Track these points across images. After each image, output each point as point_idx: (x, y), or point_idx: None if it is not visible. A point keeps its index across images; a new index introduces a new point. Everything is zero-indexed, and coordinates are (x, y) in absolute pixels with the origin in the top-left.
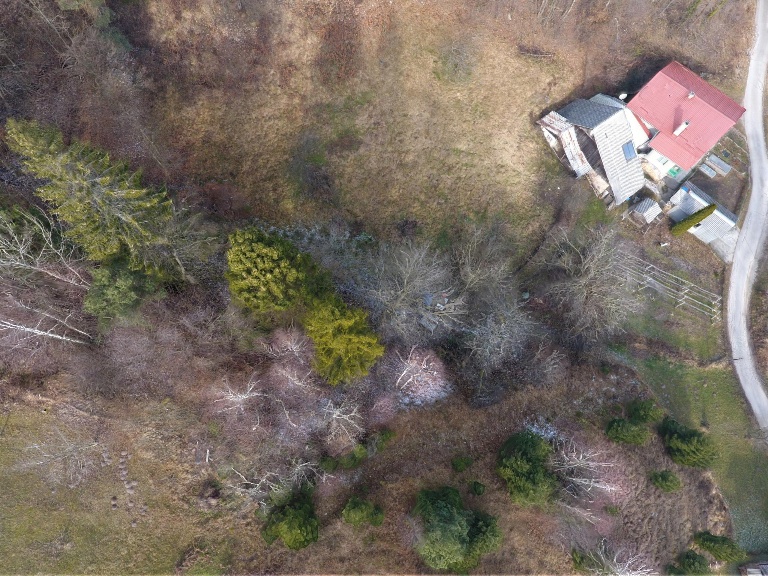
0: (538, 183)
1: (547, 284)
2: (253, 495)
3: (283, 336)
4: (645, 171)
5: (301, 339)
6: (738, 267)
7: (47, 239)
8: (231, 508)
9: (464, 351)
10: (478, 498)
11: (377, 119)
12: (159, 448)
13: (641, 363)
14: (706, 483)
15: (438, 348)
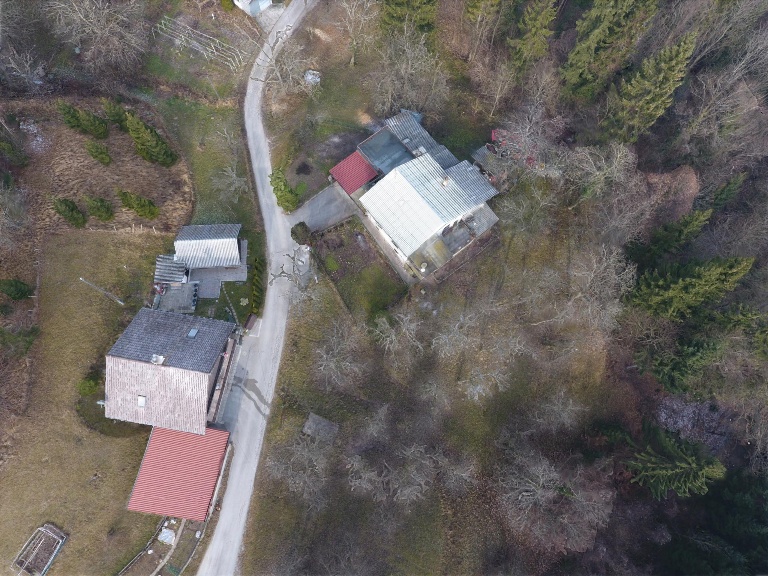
0: None
1: None
2: None
3: None
4: None
5: None
6: (274, 35)
7: None
8: None
9: (2, 85)
10: None
11: None
12: None
13: (163, 101)
14: (181, 182)
15: None
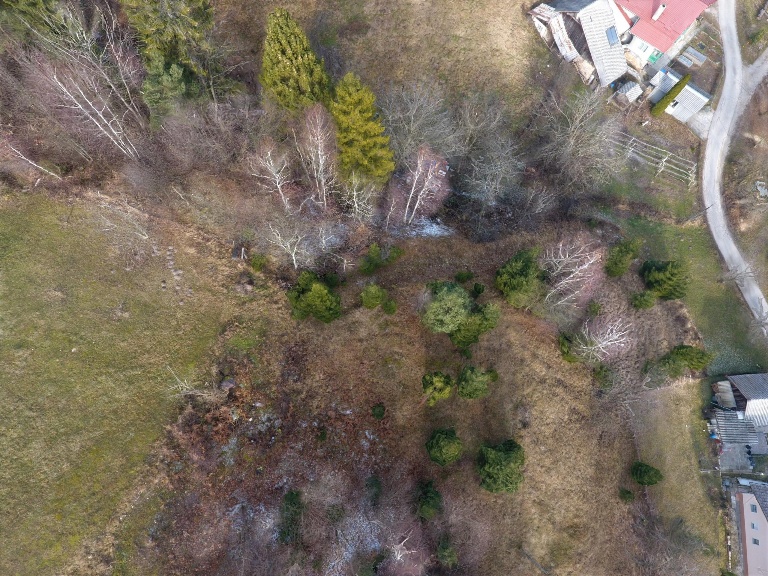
0: (530, 67)
1: (538, 148)
2: (283, 287)
3: (312, 110)
4: (628, 61)
5: (326, 121)
6: (712, 143)
7: (110, 37)
8: (264, 295)
9: (464, 209)
10: (478, 302)
11: (383, 7)
12: (200, 246)
13: (624, 222)
14: (682, 318)
15: (441, 206)
